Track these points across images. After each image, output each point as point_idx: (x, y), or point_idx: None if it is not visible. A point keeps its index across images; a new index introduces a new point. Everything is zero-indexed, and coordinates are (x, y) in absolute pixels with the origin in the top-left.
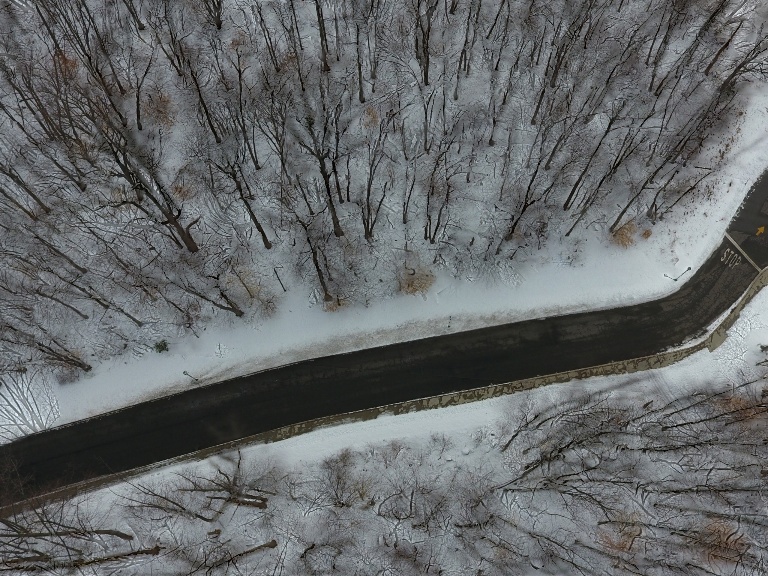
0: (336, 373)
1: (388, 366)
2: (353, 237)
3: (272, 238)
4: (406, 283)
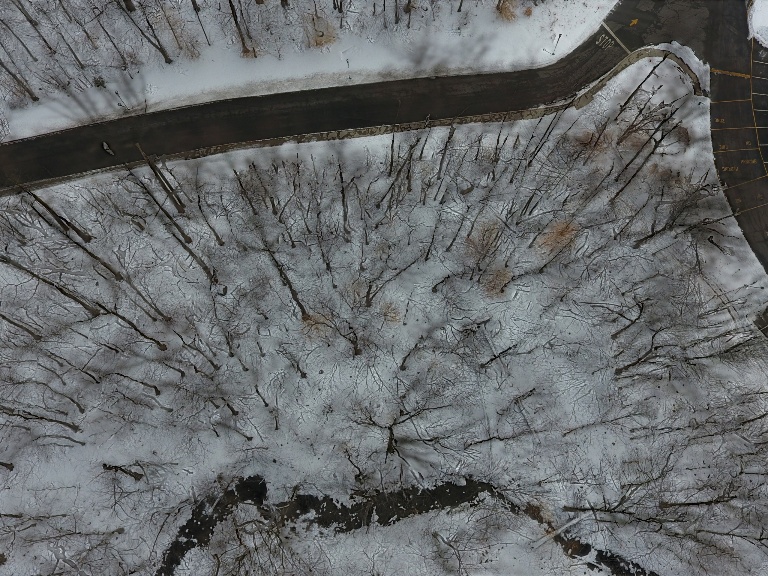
0: (250, 111)
1: (295, 107)
2: (271, 5)
3: (200, 1)
4: (314, 40)
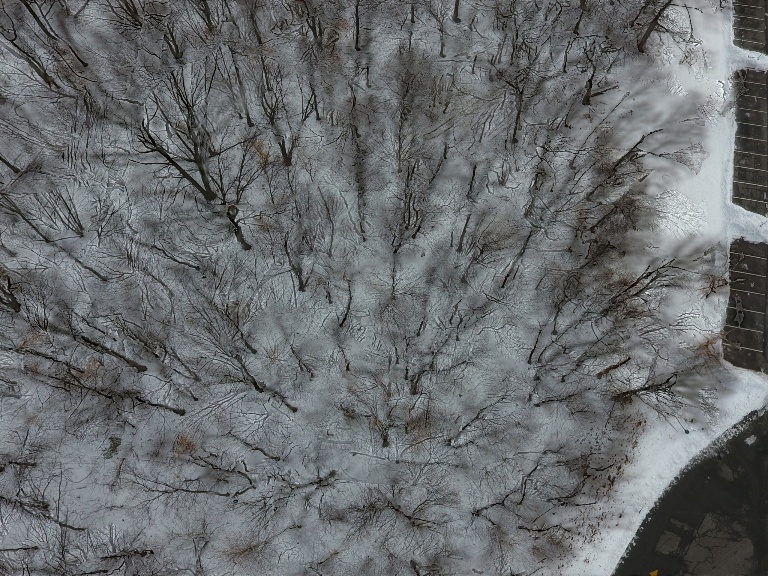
0: None
1: None
2: None
3: None
4: None
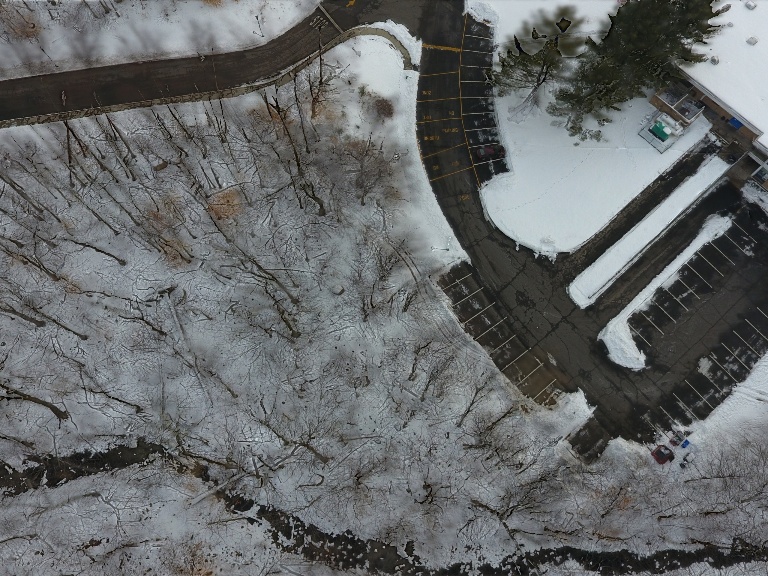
0: None
1: (1, 95)
2: None
3: None
4: None
